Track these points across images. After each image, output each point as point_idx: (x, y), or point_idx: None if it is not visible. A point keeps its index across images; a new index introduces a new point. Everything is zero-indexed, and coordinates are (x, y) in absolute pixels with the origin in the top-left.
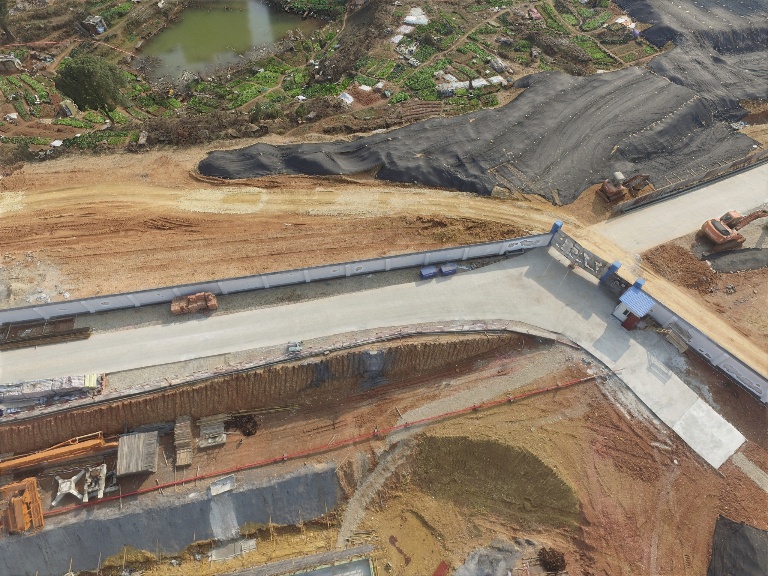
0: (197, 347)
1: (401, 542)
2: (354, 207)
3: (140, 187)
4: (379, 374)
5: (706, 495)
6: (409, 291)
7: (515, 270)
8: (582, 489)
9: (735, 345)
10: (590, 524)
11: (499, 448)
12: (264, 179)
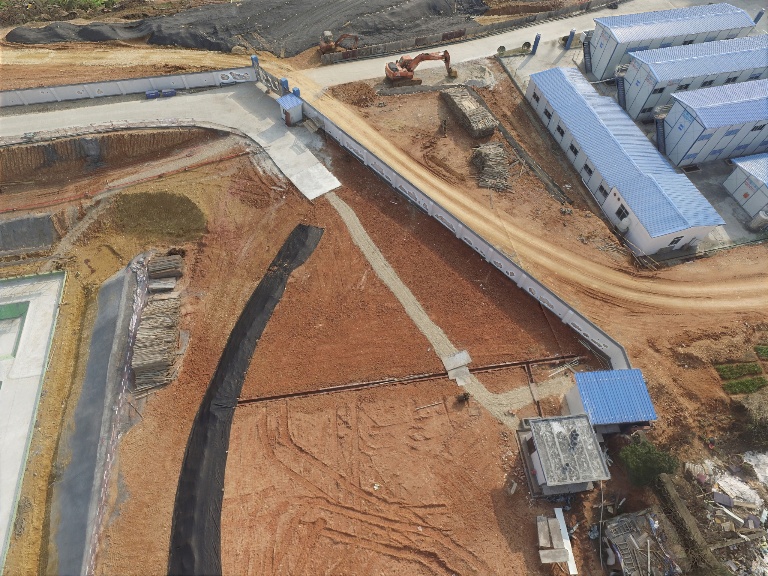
0: None
1: (92, 262)
2: (120, 60)
3: None
4: (99, 159)
5: (296, 214)
6: (134, 105)
7: (223, 94)
8: (212, 214)
9: (365, 135)
10: (209, 232)
11: (167, 196)
12: (57, 44)
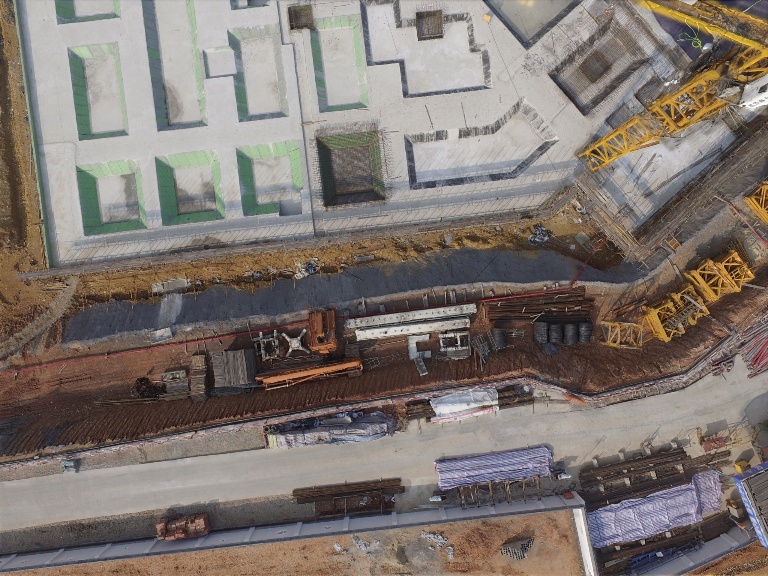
0: (176, 473)
1: None
2: None
3: None
4: (2, 431)
5: None
6: None
7: None
8: None
9: None
10: None
11: None
12: None
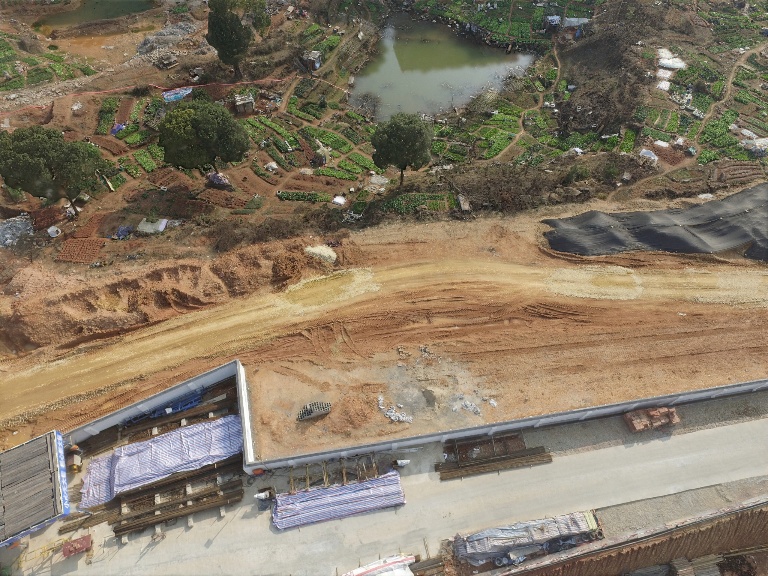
0: (679, 476)
1: None
2: (743, 293)
3: (495, 264)
4: None
5: None
6: None
7: None
8: None
9: None
10: None
11: None
12: (624, 256)
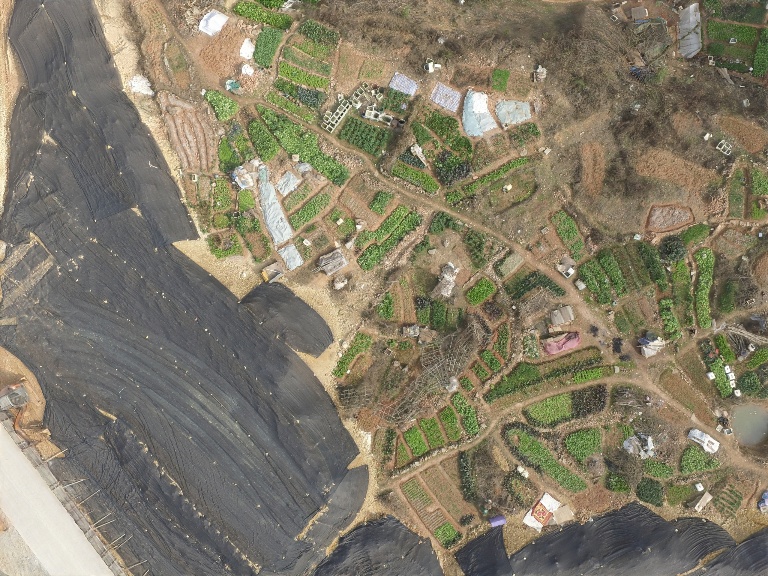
0: None
1: None
2: None
3: None
4: None
5: None
6: None
7: None
8: None
9: None
10: None
11: None
12: None
